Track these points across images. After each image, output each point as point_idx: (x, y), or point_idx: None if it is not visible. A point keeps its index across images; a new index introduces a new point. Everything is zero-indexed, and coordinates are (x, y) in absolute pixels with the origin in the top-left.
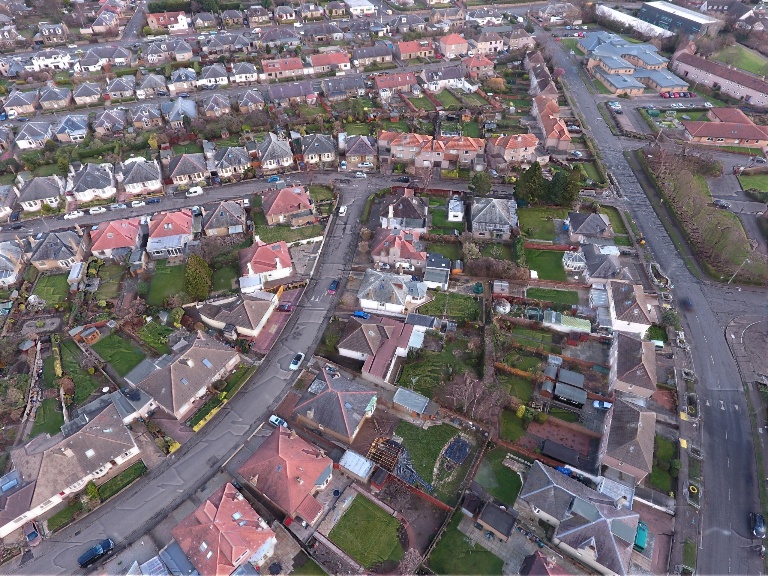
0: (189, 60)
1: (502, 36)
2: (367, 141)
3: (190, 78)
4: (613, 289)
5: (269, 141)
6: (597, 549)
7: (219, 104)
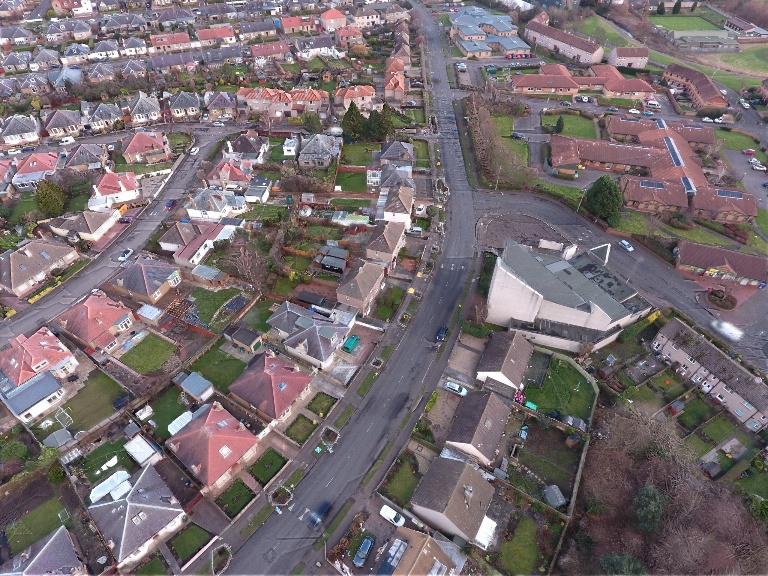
0: (86, 38)
1: (380, 12)
2: (227, 96)
3: (81, 52)
4: (389, 192)
5: (138, 98)
6: (308, 346)
7: (103, 72)
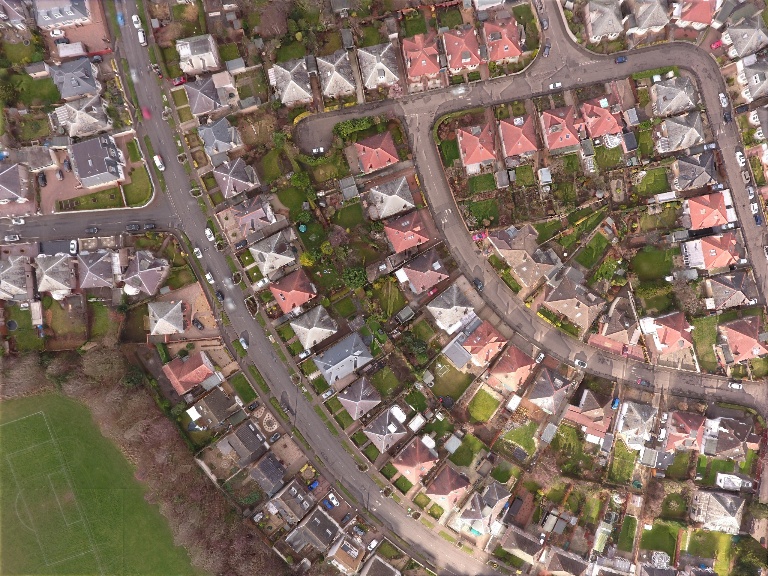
0: None
1: None
2: None
3: None
4: None
5: None
6: (471, 511)
7: None
